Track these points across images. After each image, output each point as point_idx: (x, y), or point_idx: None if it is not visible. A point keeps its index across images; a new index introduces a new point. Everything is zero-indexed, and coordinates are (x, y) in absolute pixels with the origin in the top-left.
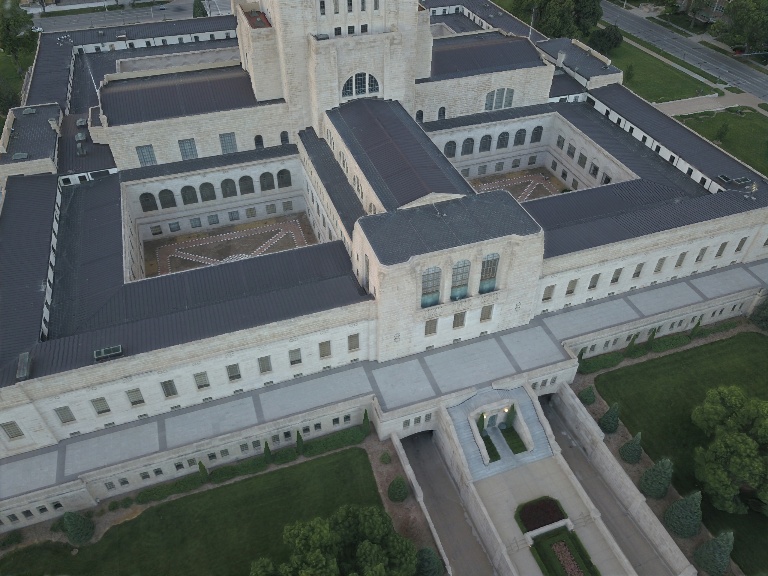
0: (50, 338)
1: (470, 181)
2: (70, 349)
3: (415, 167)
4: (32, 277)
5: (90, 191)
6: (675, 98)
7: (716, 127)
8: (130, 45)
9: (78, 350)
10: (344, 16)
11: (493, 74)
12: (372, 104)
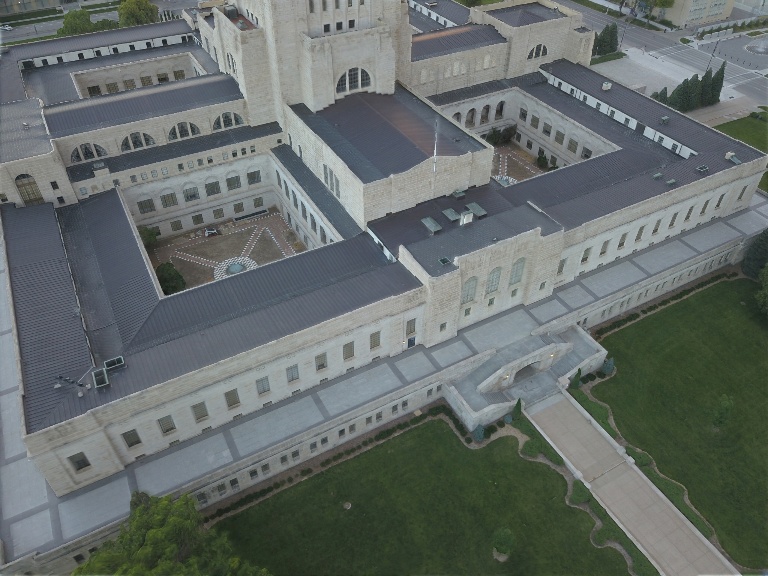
0: (38, 69)
1: (300, 241)
2: (5, 67)
3: (93, 107)
4: (76, 47)
5: (186, 48)
6: (681, 504)
7: (577, 567)
8: (429, 14)
9: (2, 68)
10: (248, 1)
11: (324, 145)
12: (224, 84)
